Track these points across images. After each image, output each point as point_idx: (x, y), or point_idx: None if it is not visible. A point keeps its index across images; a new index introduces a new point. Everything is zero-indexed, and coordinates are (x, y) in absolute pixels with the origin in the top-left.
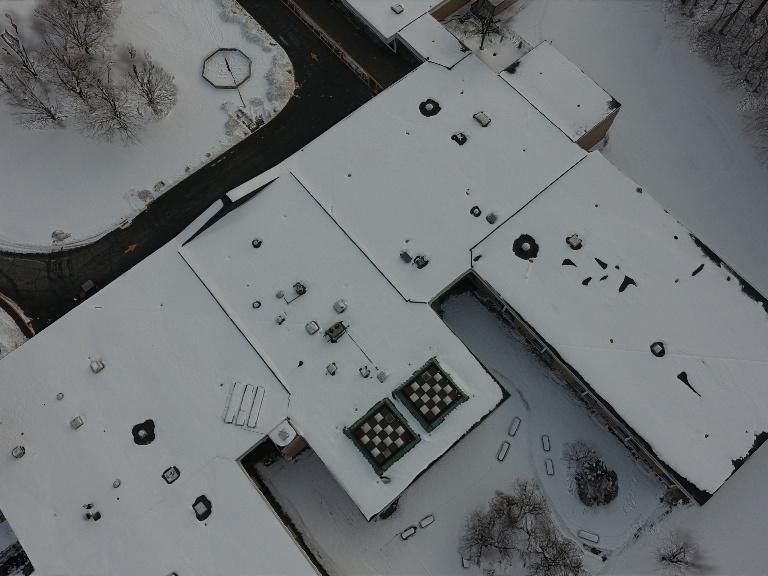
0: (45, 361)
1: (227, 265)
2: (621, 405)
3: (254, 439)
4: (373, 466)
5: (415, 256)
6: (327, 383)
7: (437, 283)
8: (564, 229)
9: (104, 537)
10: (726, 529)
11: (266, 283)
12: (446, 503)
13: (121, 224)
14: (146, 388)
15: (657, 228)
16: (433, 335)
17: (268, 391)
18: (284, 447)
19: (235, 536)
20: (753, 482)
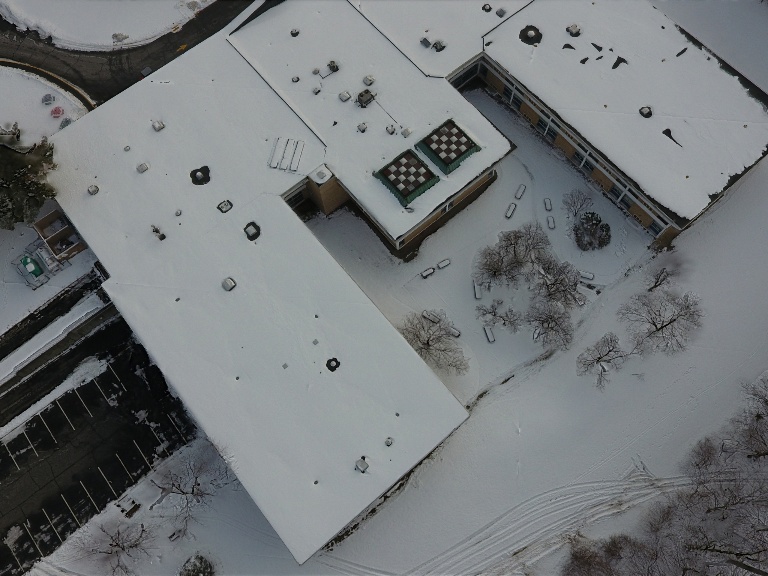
0: (113, 122)
1: (269, 50)
2: (613, 153)
3: (296, 180)
4: (399, 199)
5: (434, 42)
6: (358, 138)
7: (453, 63)
8: (565, 21)
9: (169, 252)
10: (705, 270)
11: (304, 63)
12: (461, 250)
13: (173, 29)
14: (201, 142)
15: (646, 20)
16: (450, 102)
17: (307, 144)
18: (322, 184)
19: (281, 251)
20: (729, 234)
